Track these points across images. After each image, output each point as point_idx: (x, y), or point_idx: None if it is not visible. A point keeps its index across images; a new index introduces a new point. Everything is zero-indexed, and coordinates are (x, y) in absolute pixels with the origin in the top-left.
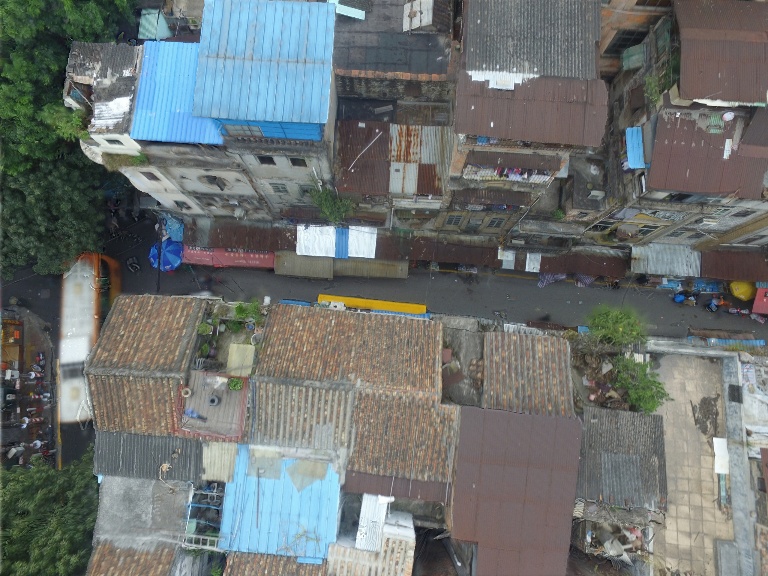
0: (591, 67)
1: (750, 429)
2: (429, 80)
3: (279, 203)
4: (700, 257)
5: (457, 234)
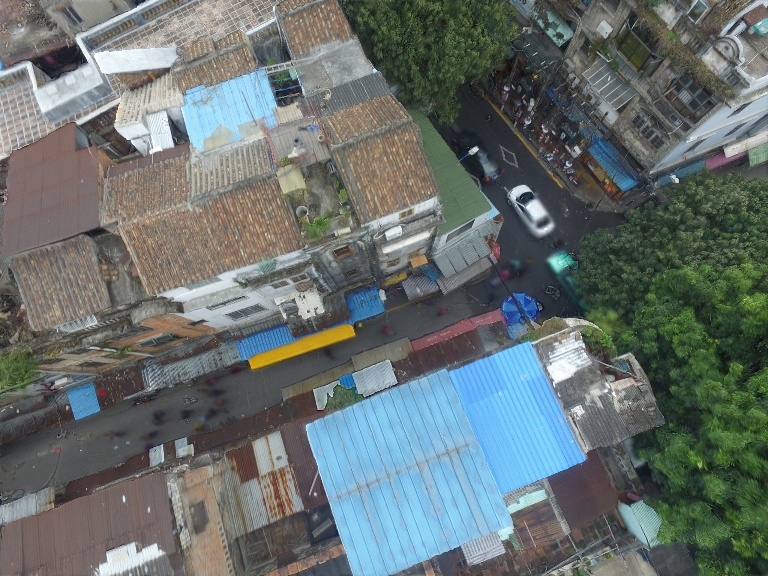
0: None
1: None
2: (266, 575)
3: None
4: None
5: None
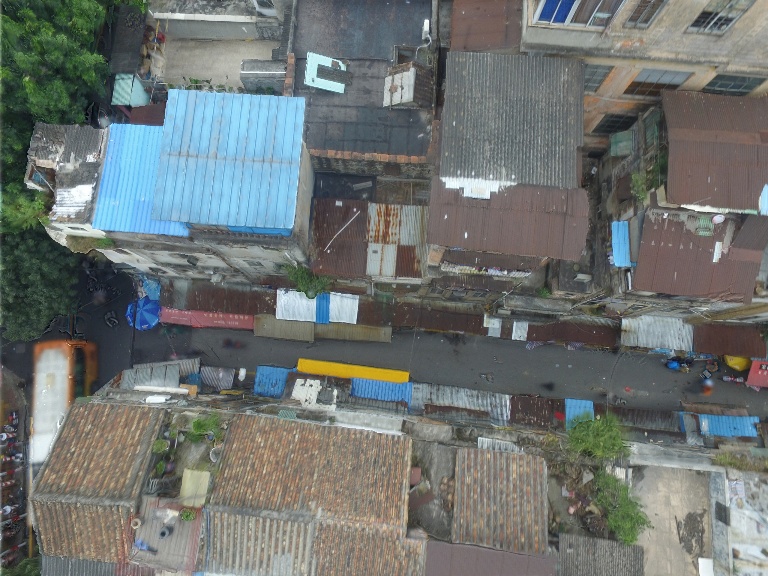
0: (572, 175)
1: (738, 549)
2: (408, 162)
3: (256, 273)
4: (693, 331)
5: (442, 301)
